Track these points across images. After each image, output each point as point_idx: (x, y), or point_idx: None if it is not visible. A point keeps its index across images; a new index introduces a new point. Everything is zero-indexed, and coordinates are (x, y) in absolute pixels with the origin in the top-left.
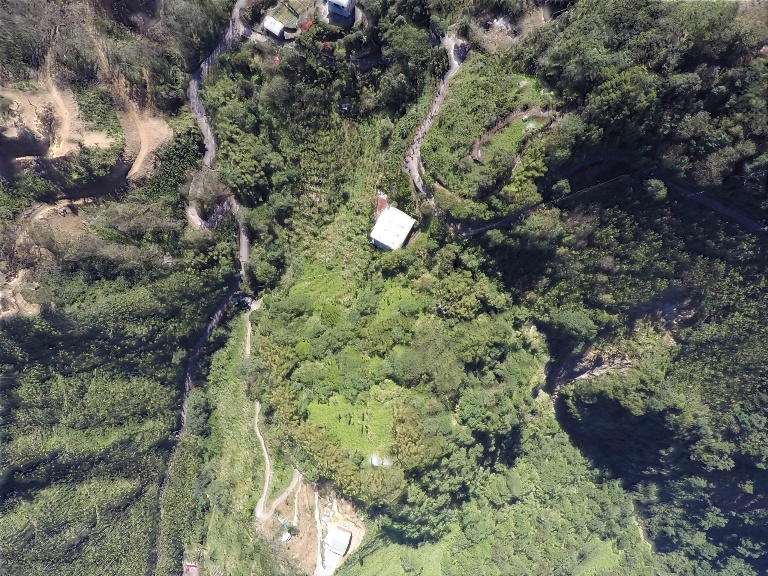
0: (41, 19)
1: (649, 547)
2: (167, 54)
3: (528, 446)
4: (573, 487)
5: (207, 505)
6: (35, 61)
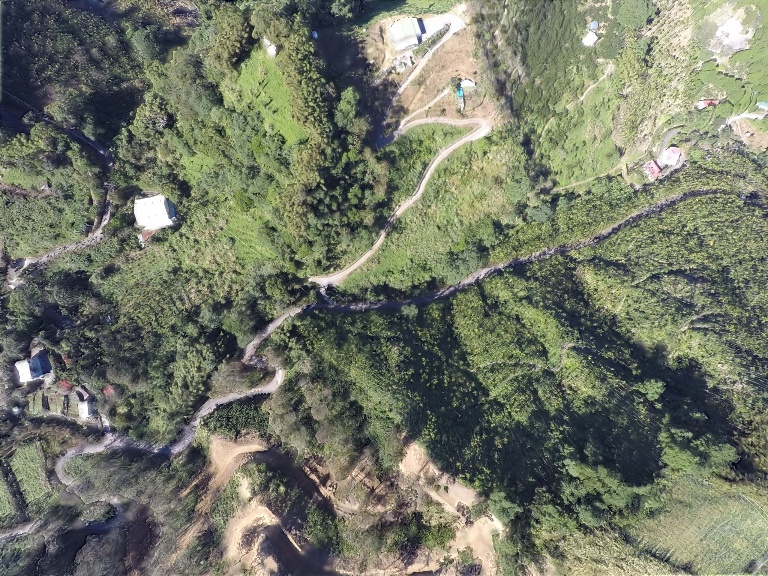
0: None
1: None
2: None
3: None
4: None
5: (570, 197)
6: None
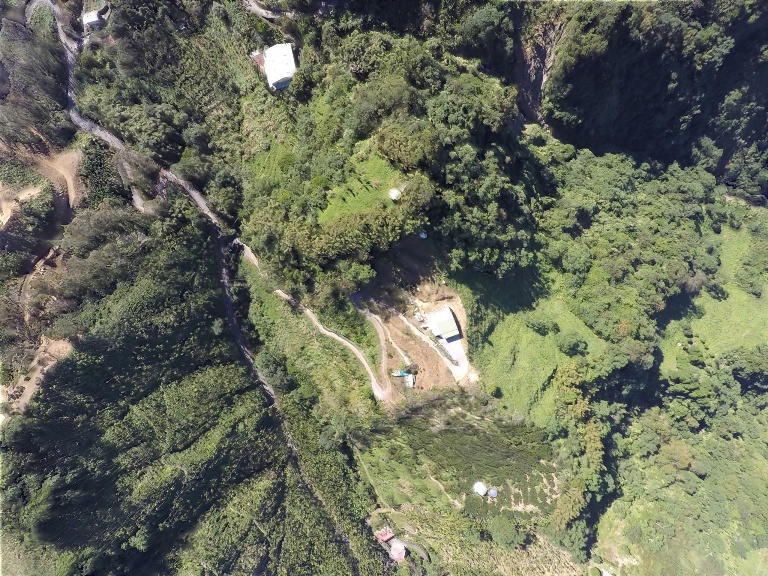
0: None
1: (763, 198)
2: (37, 101)
3: (558, 174)
4: (640, 194)
5: (353, 463)
6: None
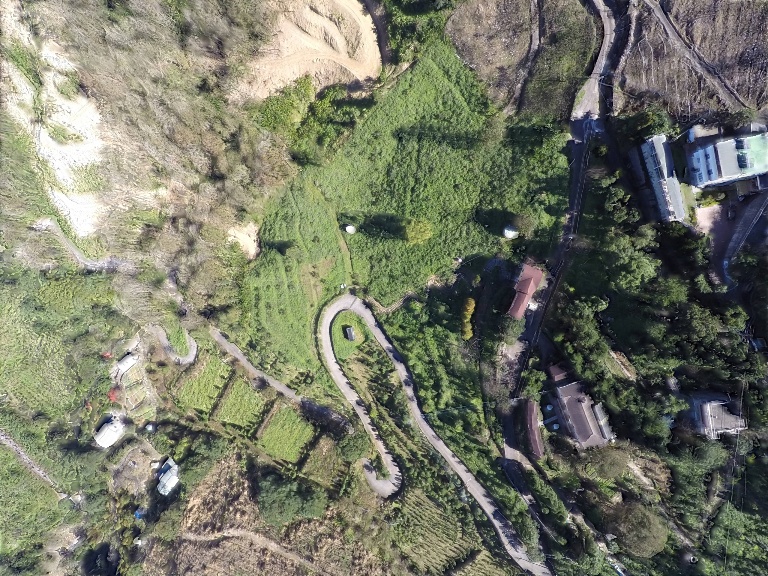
0: None
1: None
2: None
3: None
4: None
5: None
6: None
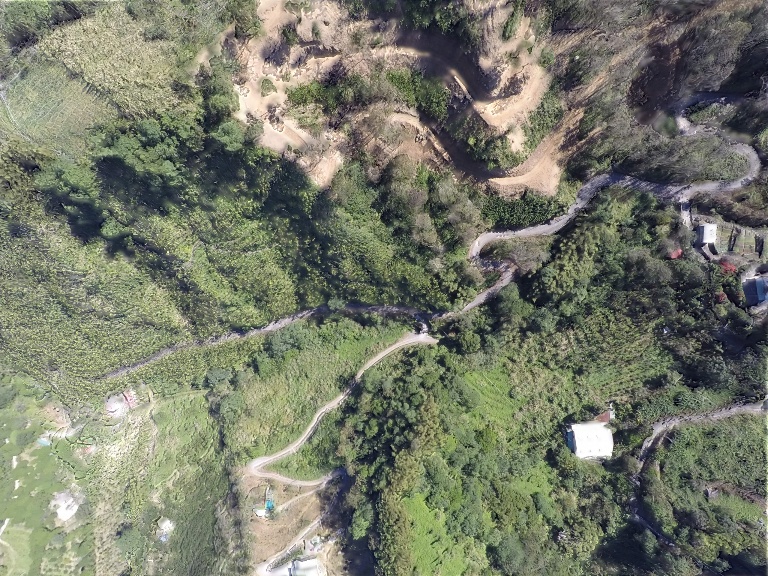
0: (606, 18)
1: None
2: (628, 148)
3: None
4: None
5: None
6: (561, 36)
